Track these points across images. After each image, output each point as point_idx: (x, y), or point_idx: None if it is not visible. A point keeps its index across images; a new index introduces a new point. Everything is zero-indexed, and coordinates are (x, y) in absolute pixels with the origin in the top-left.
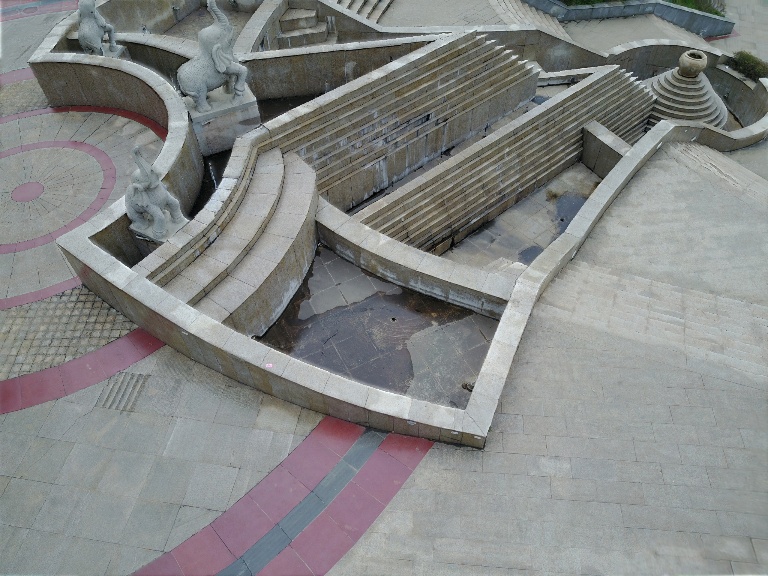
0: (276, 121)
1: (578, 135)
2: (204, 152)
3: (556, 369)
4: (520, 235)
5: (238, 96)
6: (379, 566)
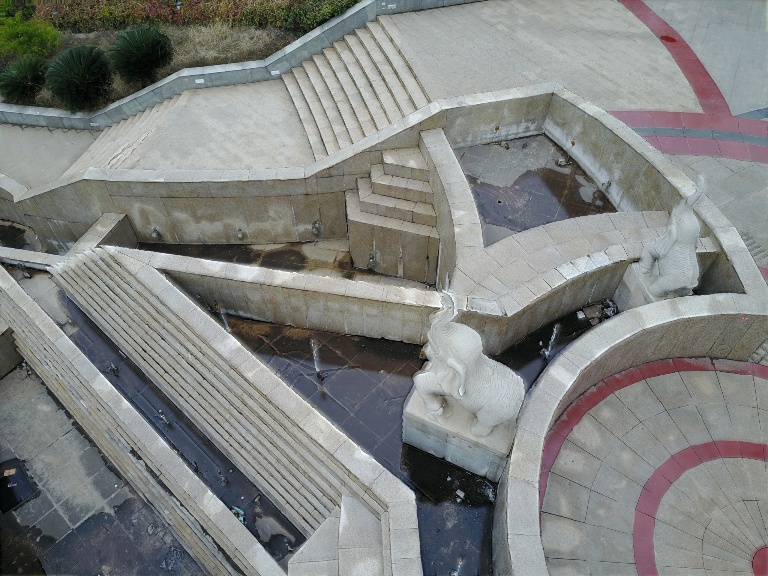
0: None
1: None
2: None
3: (473, 93)
4: None
5: None
6: (648, 100)
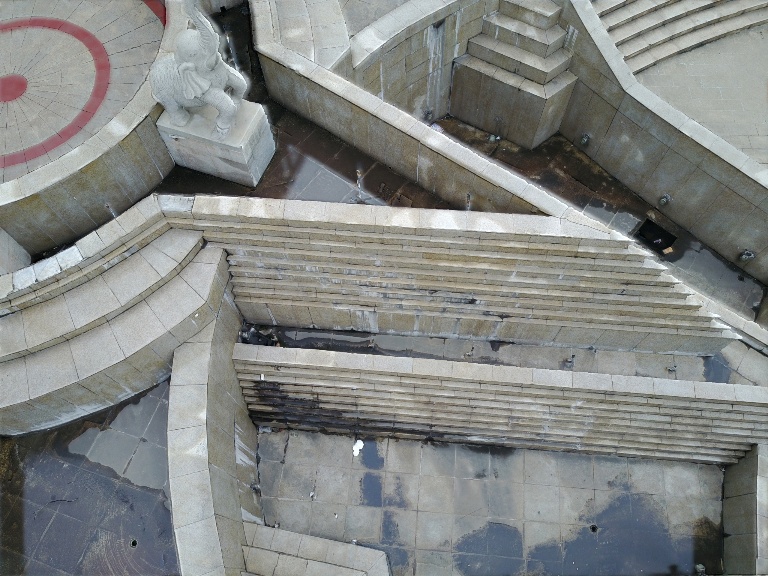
0: (213, 202)
1: (742, 445)
2: (177, 160)
3: None
4: (519, 499)
5: (217, 131)
6: None
